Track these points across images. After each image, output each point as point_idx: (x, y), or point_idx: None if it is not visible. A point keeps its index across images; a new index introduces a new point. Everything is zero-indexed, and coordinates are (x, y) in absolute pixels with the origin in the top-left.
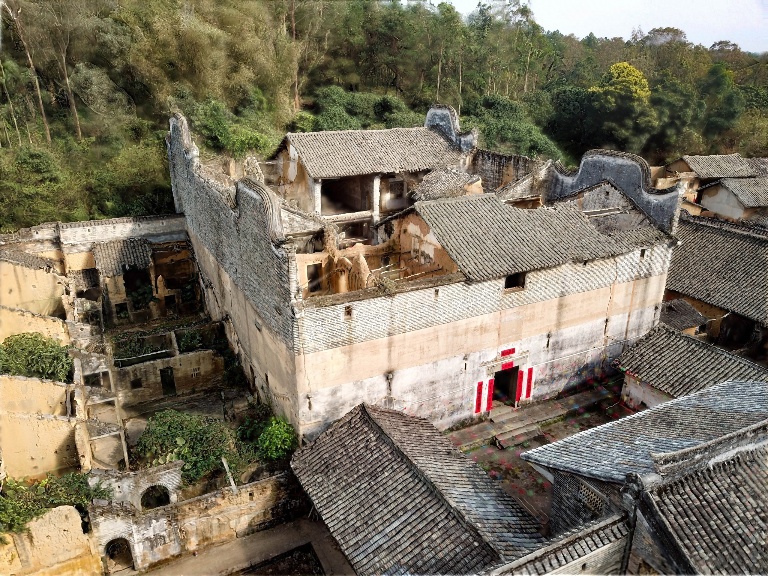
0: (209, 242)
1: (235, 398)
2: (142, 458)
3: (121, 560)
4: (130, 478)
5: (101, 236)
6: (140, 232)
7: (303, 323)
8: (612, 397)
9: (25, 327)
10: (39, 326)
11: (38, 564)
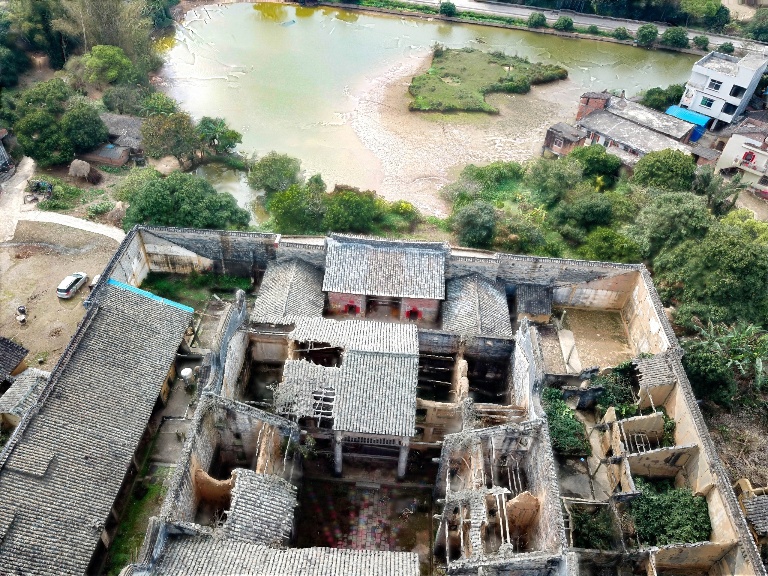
0: None
1: None
2: None
3: None
4: None
5: None
6: None
7: None
8: None
9: None
10: None
11: None
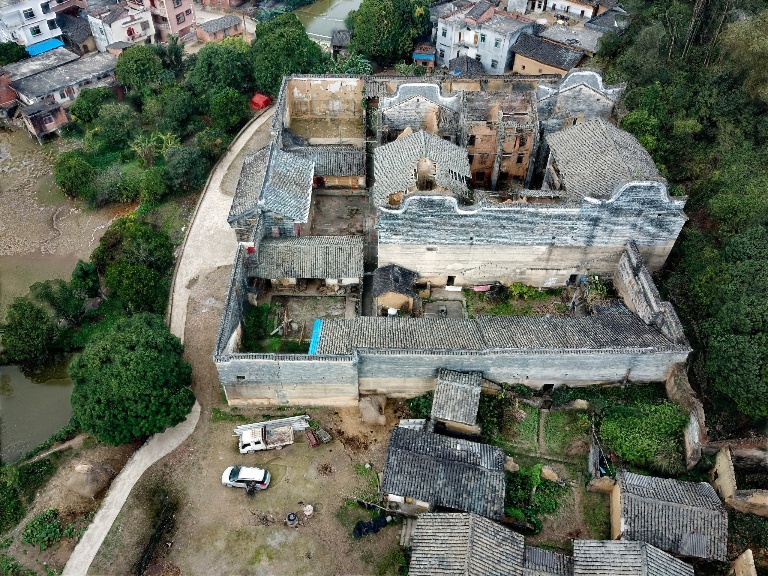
0: None
1: None
2: None
3: (370, 139)
4: None
5: None
6: None
7: None
8: (368, 260)
9: None
10: None
11: None
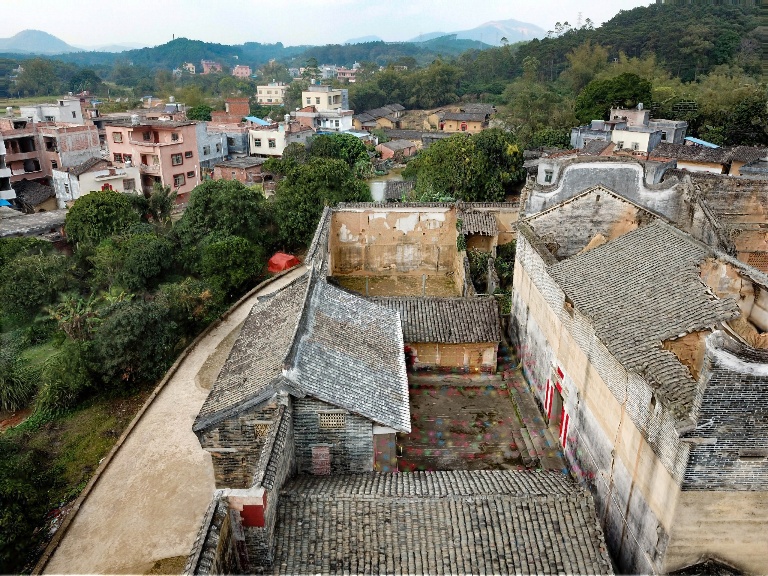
0: None
1: None
2: None
3: None
4: None
5: None
6: None
7: None
8: None
9: None
10: None
11: None
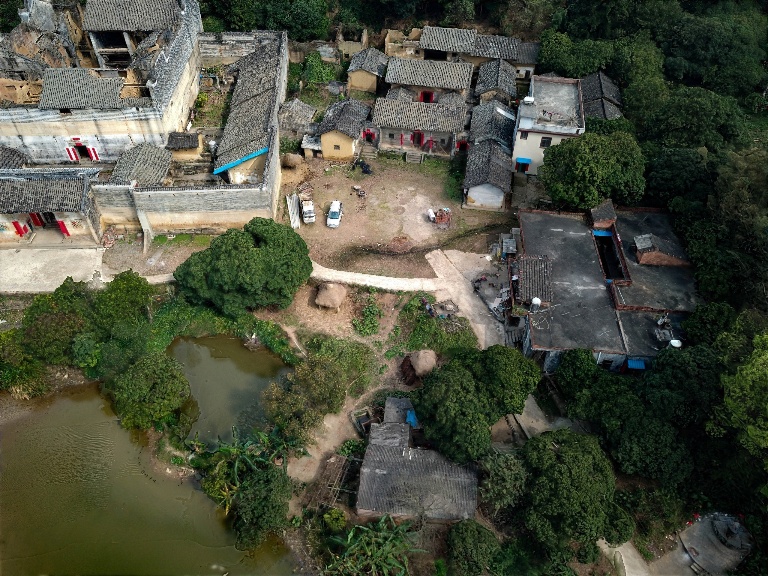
0: None
1: None
2: None
3: None
4: None
5: None
6: None
7: None
8: None
9: None
10: None
11: None
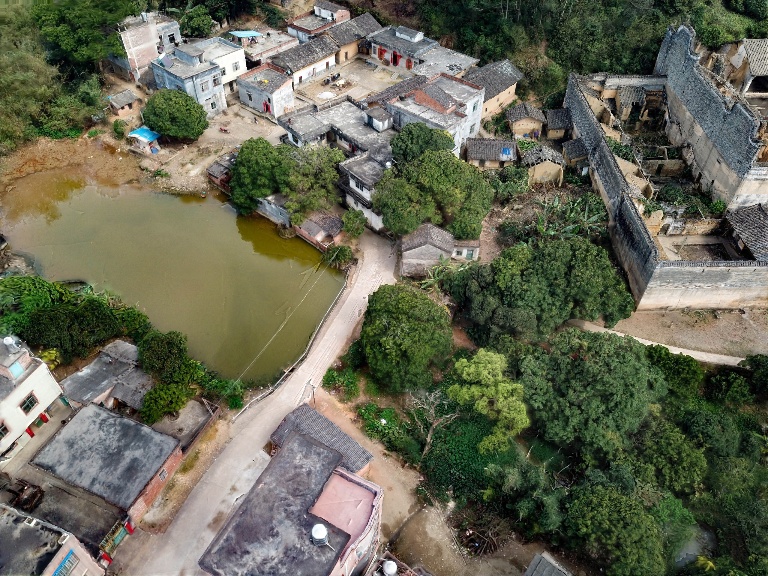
0: (691, 106)
1: (686, 184)
2: (663, 200)
3: None
4: (671, 207)
5: (624, 83)
6: (642, 83)
7: (751, 171)
8: None
9: (608, 134)
10: (613, 134)
11: (647, 224)
